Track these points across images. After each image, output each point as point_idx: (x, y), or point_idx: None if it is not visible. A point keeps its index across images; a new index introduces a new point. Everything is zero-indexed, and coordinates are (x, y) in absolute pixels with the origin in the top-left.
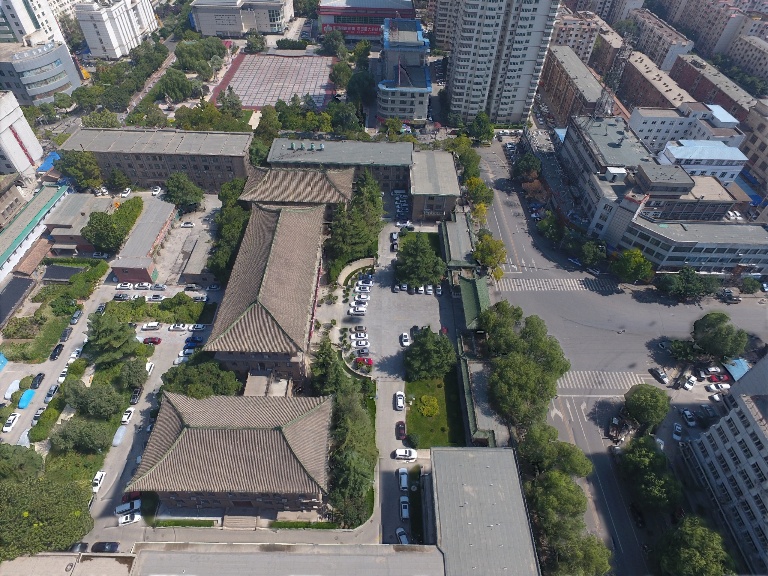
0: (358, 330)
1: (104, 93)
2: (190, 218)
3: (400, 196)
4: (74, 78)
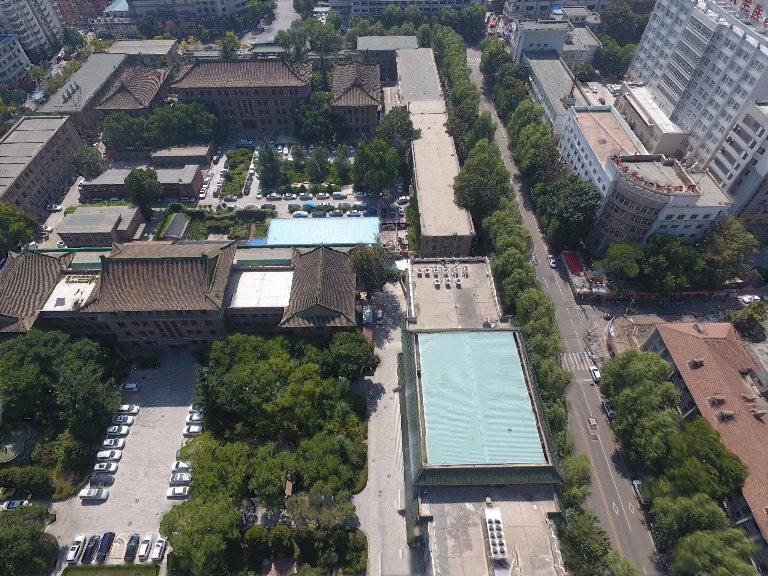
0: None
1: None
2: None
3: None
4: None
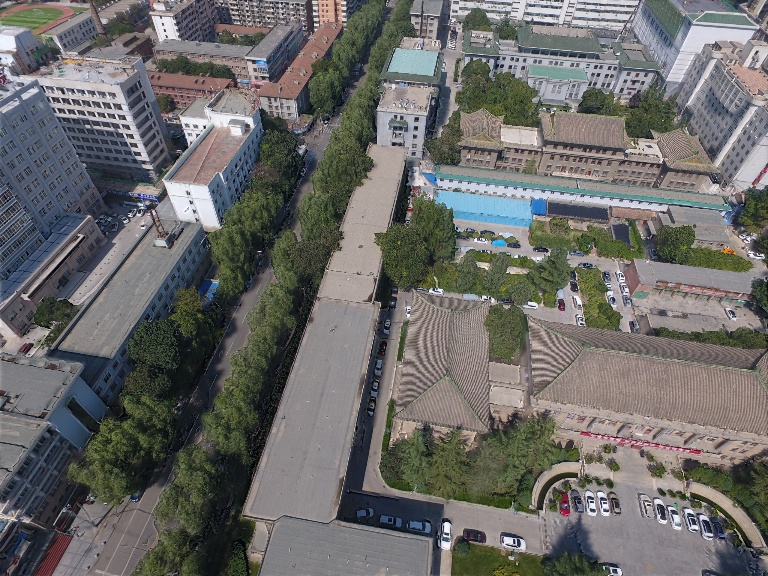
0: (613, 502)
1: None
2: (745, 315)
3: None
4: None
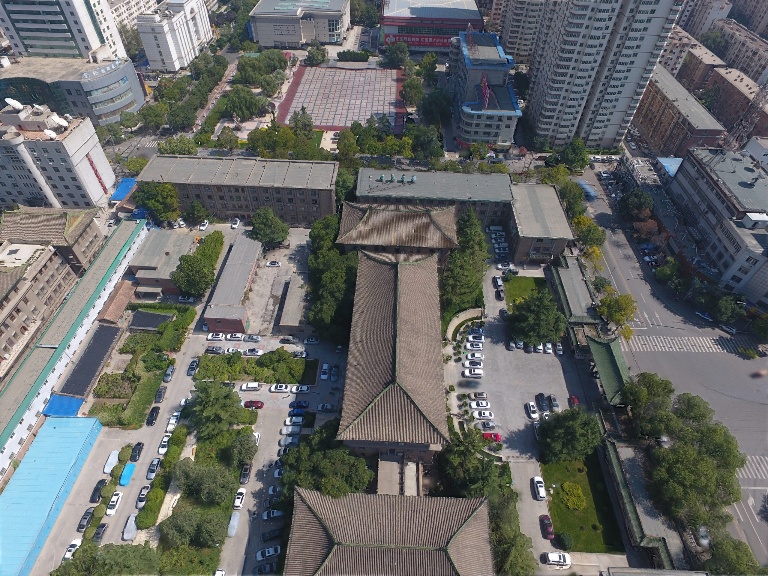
0: (478, 397)
1: (171, 112)
2: (275, 256)
3: (497, 233)
4: (138, 95)
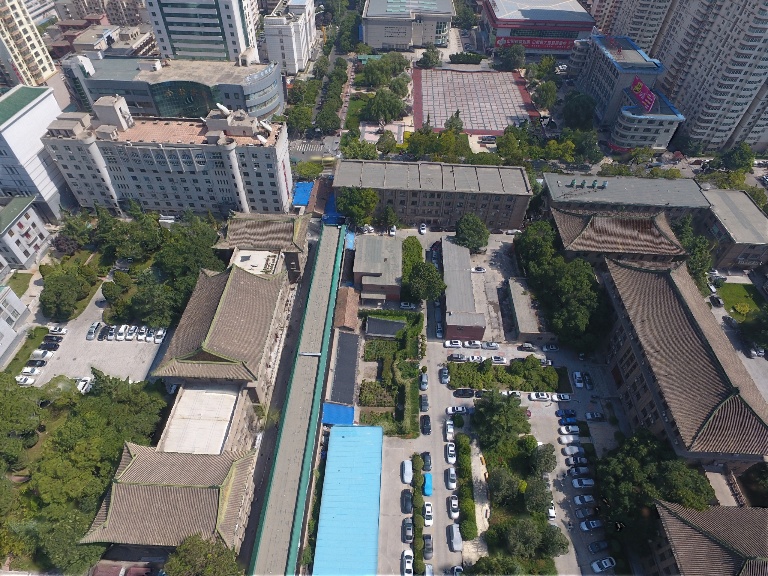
0: None
1: (322, 116)
2: (475, 261)
3: None
4: (281, 98)
